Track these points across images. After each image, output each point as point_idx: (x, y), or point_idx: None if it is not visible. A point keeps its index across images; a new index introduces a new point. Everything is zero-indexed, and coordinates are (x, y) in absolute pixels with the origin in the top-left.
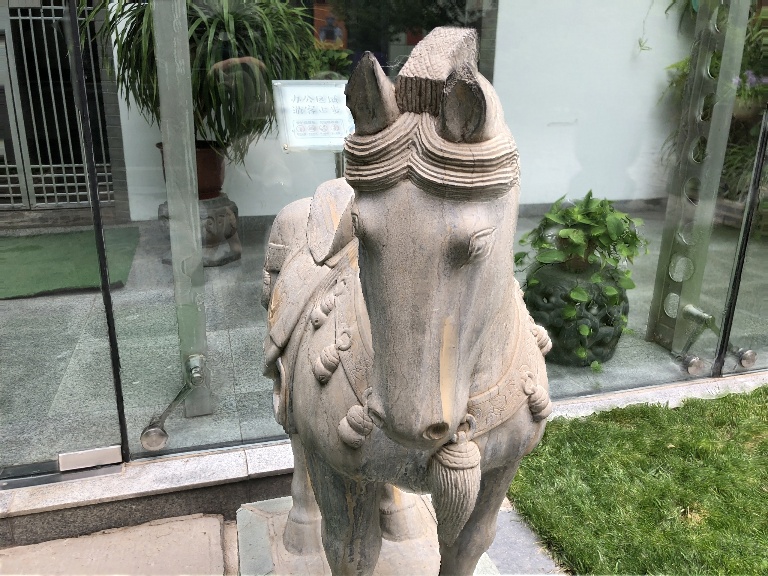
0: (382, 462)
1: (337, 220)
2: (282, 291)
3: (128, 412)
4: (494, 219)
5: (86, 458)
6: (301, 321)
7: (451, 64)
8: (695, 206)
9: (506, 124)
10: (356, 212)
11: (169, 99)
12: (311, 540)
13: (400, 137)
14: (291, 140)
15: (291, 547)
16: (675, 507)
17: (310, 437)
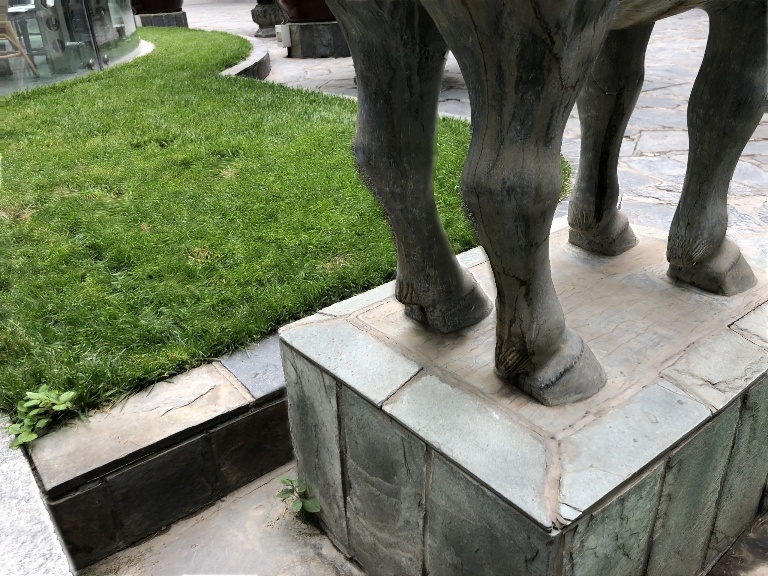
0: None
1: None
2: None
3: None
4: None
5: None
6: None
7: None
8: None
9: None
10: None
11: None
12: None
13: None
14: None
15: None
16: None
17: None
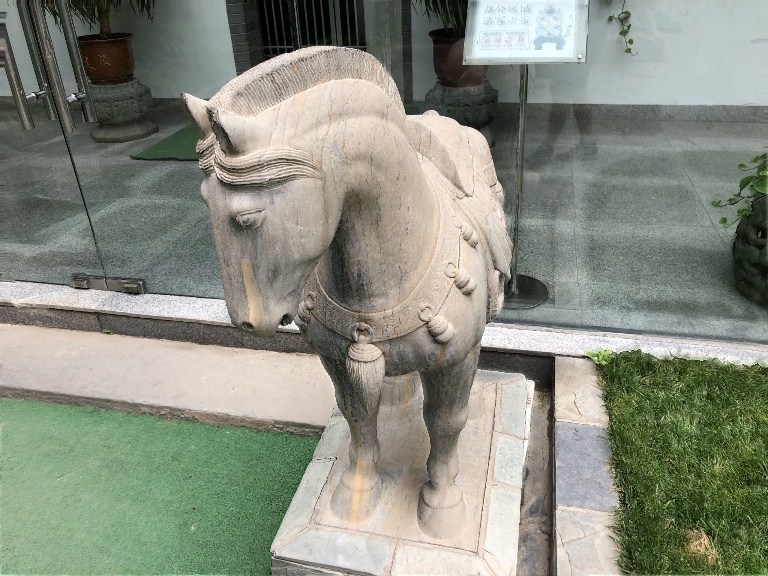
0: (320, 343)
1: None
2: None
3: None
4: (258, 204)
5: None
6: None
7: (232, 103)
8: None
9: (310, 133)
10: None
11: (373, 13)
12: (388, 396)
13: (208, 147)
14: (473, 52)
15: None
16: None
17: None
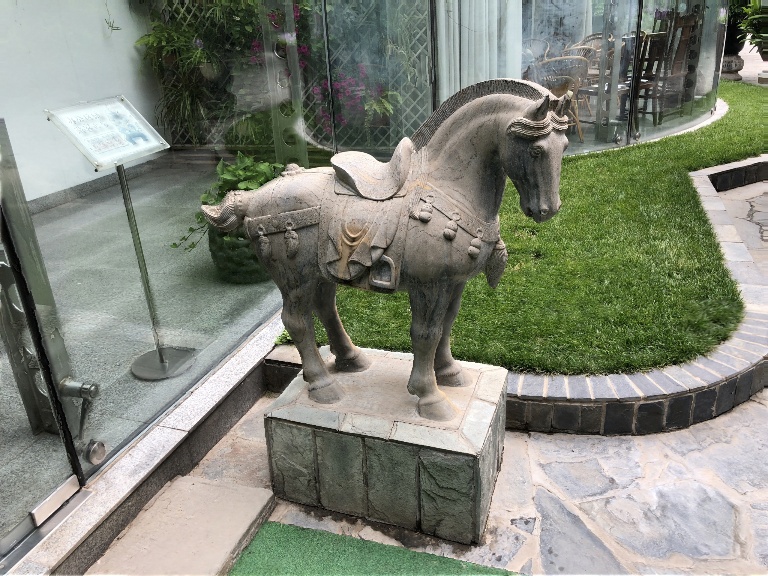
0: None
1: (369, 177)
2: (362, 223)
3: (3, 473)
4: None
5: (53, 502)
6: (400, 227)
7: None
8: (288, 147)
9: None
10: (541, 145)
11: None
12: (339, 390)
13: None
14: (96, 157)
15: (332, 400)
16: (406, 310)
17: (443, 270)
